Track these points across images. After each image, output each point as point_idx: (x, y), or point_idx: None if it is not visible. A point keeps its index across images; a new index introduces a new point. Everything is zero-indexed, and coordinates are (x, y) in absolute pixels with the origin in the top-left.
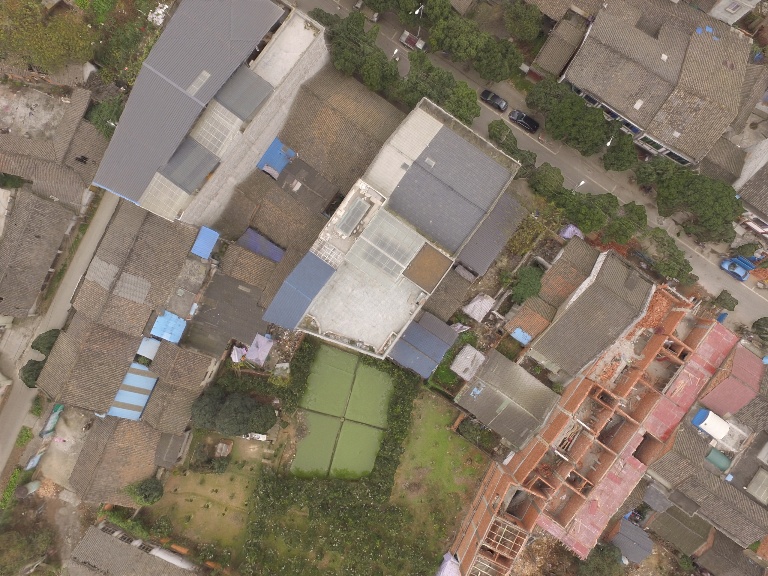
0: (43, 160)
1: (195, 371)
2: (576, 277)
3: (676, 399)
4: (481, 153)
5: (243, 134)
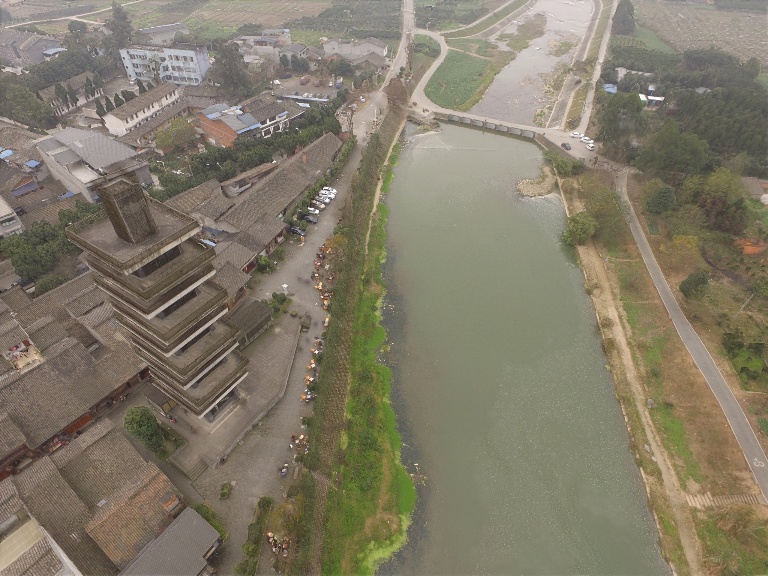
0: (122, 137)
1: None
2: None
3: None
4: None
5: None
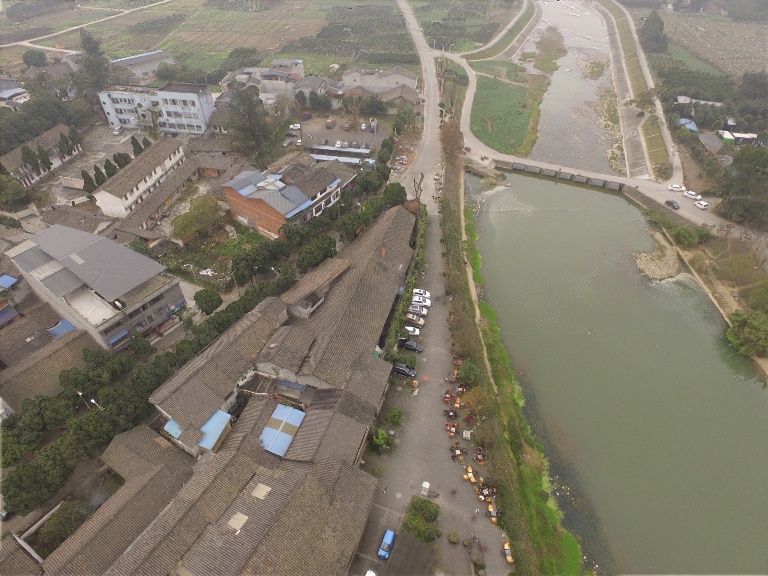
0: (124, 223)
1: None
2: None
3: None
4: None
5: (46, 288)
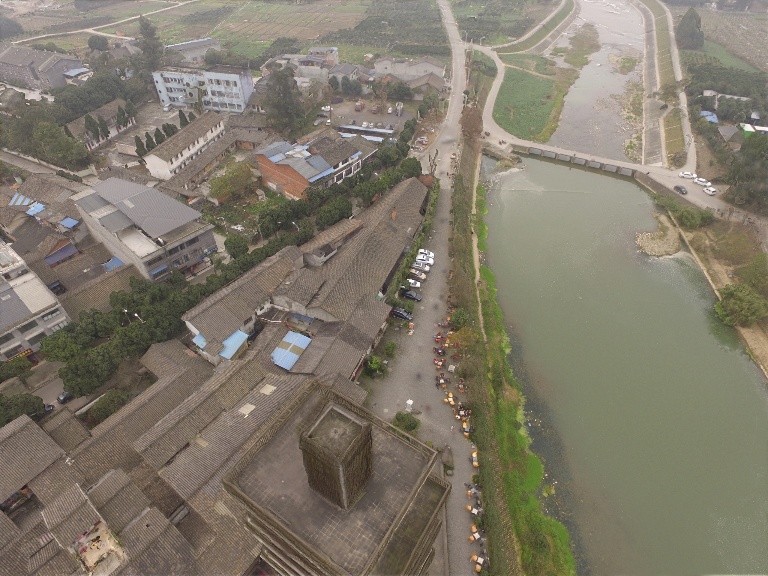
0: (168, 183)
1: (5, 218)
2: None
3: None
4: None
5: None
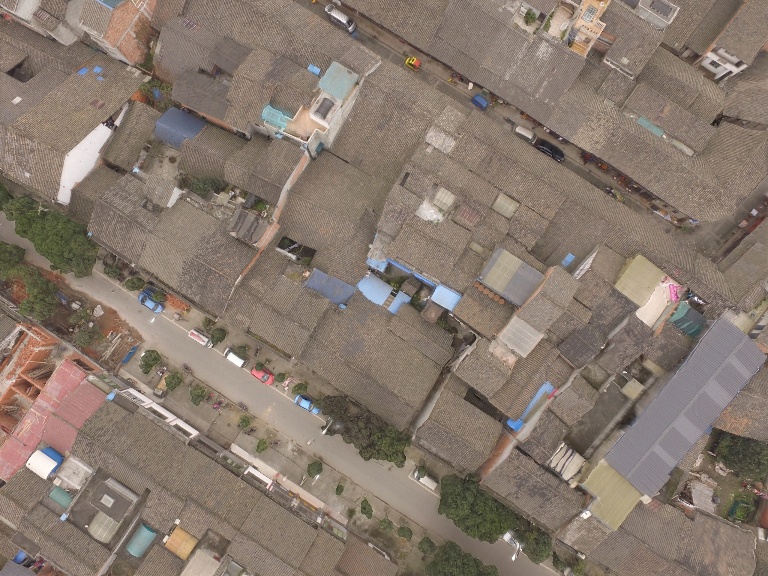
0: None
1: None
2: None
3: (23, 439)
4: None
5: None
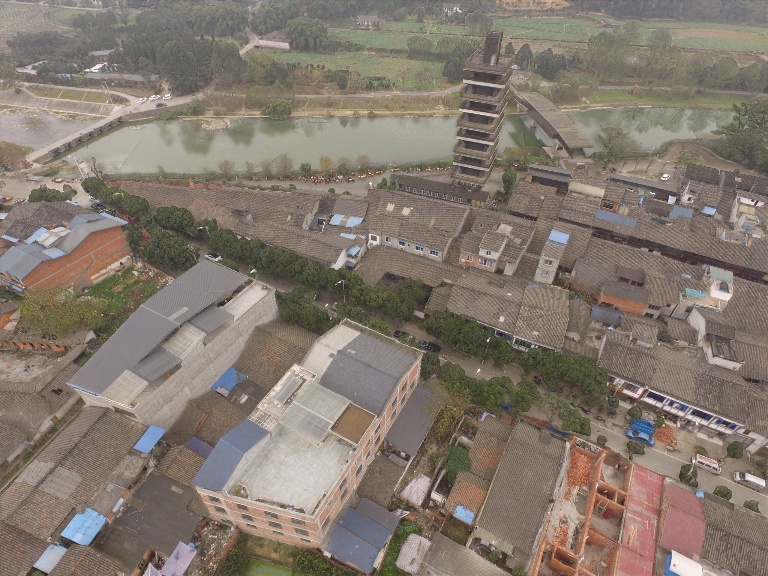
0: (22, 394)
1: None
2: (498, 446)
3: (635, 548)
4: (391, 347)
5: (205, 347)
